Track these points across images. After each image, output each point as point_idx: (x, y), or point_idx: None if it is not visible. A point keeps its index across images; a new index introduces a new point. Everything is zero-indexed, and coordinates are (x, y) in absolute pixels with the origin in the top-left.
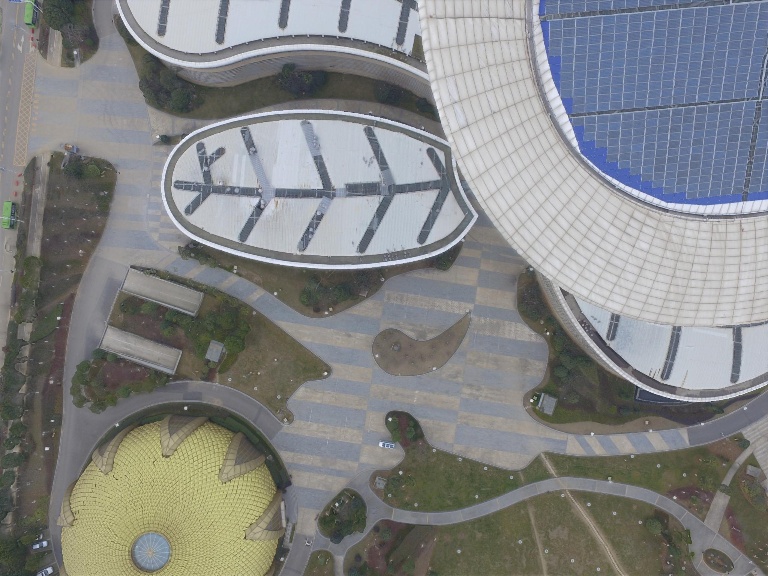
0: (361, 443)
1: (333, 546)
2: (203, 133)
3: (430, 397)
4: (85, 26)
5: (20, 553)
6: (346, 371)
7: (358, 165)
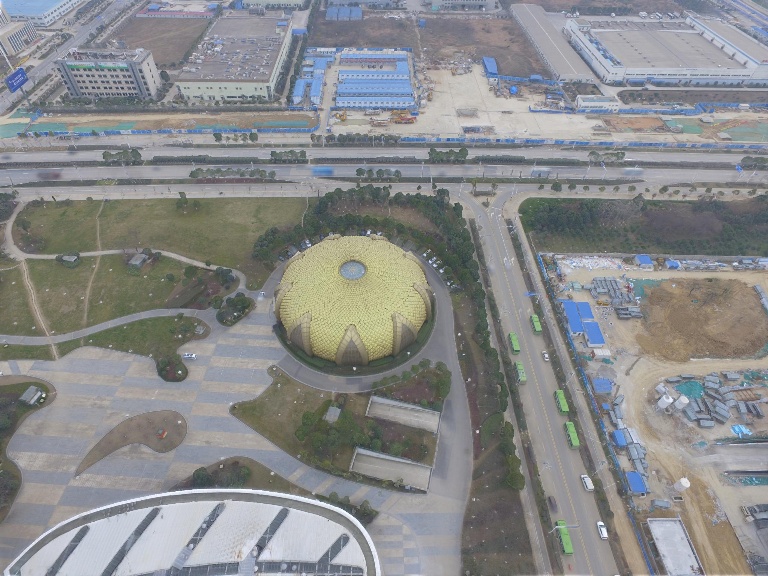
0: (212, 357)
1: (245, 293)
2: None
3: (142, 395)
4: None
5: (459, 276)
6: (216, 411)
7: None
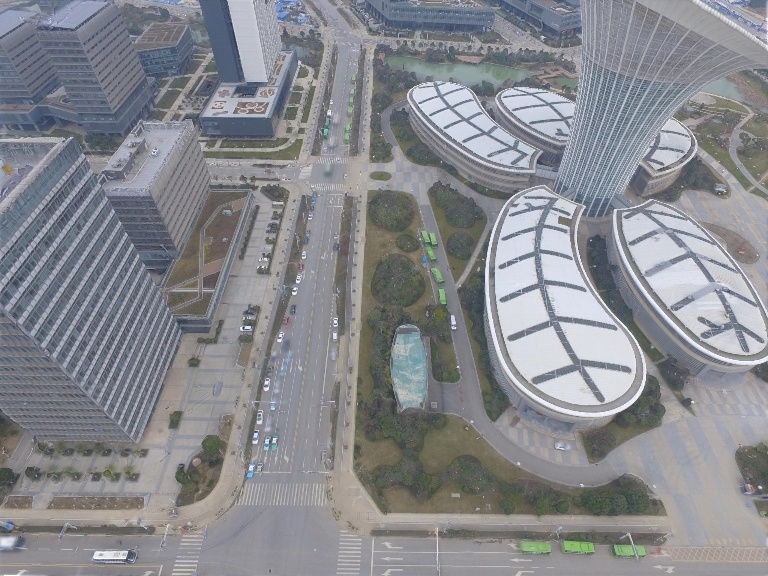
0: None
1: None
2: (691, 338)
3: (757, 236)
4: (625, 475)
5: None
6: None
7: (662, 243)
